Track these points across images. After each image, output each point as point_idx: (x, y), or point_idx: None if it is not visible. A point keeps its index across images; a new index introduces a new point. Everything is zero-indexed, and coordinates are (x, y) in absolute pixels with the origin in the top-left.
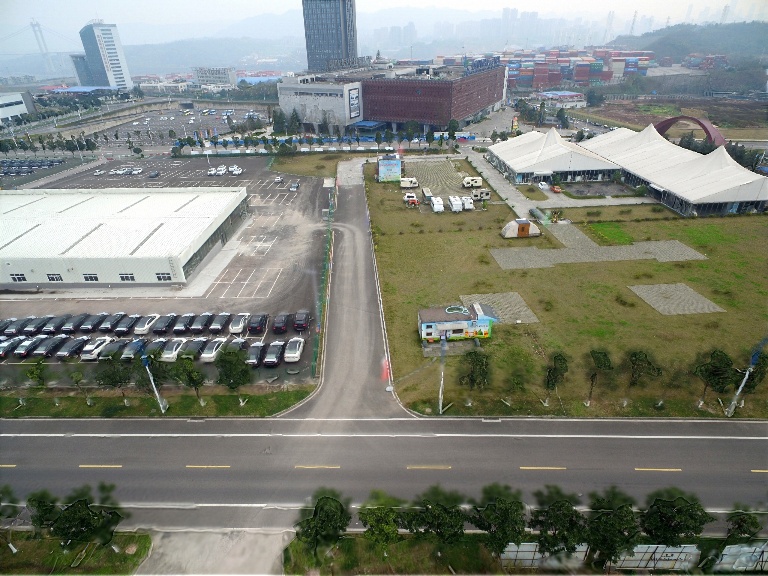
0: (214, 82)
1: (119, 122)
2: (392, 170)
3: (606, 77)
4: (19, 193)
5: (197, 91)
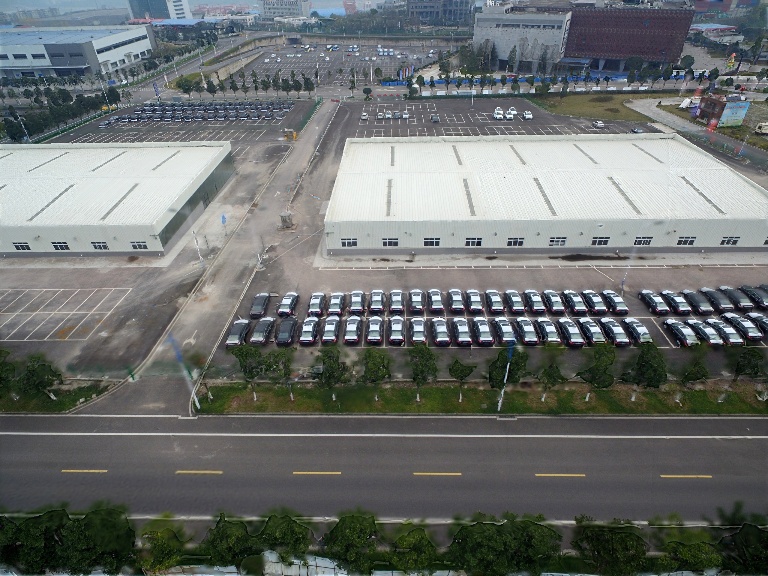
0: (283, 14)
1: (249, 59)
2: (737, 113)
3: (725, 8)
4: (412, 140)
5: (268, 25)
